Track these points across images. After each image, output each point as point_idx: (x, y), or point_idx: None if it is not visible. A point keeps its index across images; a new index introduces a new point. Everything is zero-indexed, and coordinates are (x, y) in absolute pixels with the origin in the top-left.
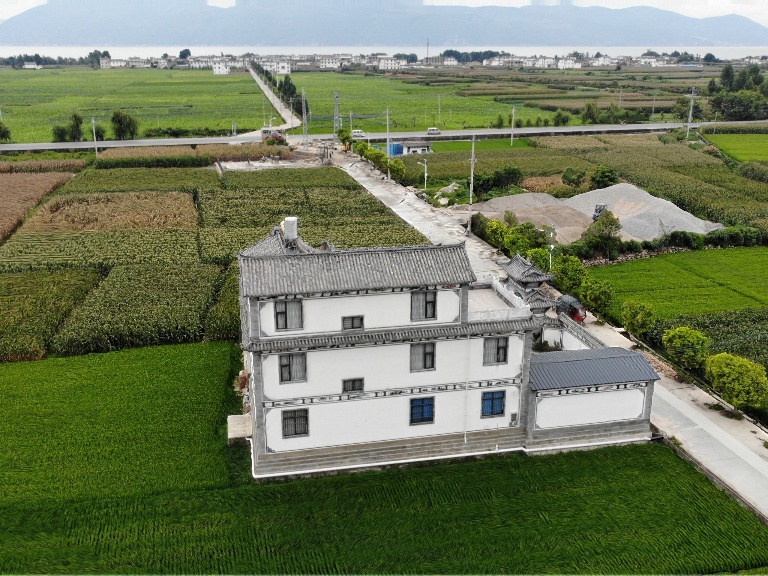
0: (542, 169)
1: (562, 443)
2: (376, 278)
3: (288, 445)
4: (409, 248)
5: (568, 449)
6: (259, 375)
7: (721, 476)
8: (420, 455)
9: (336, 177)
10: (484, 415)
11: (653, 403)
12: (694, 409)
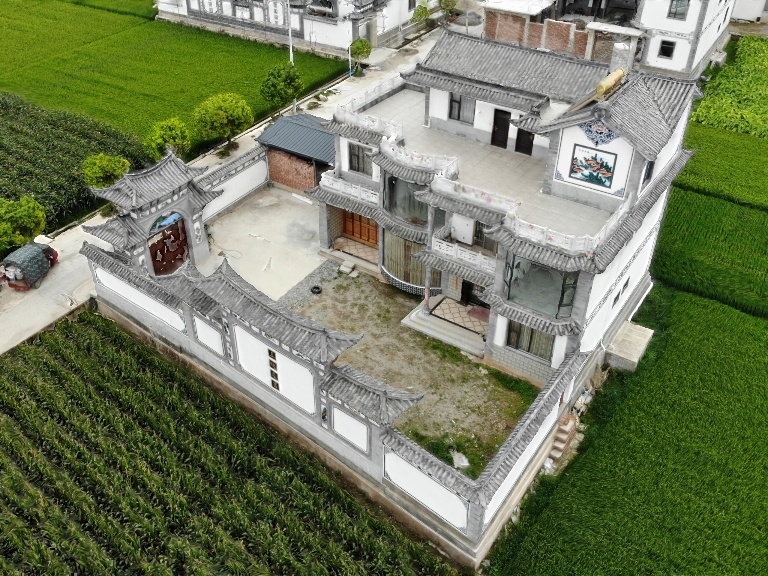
0: None
1: None
2: None
3: None
4: None
5: None
6: None
7: None
8: None
9: None
10: None
11: None
12: None
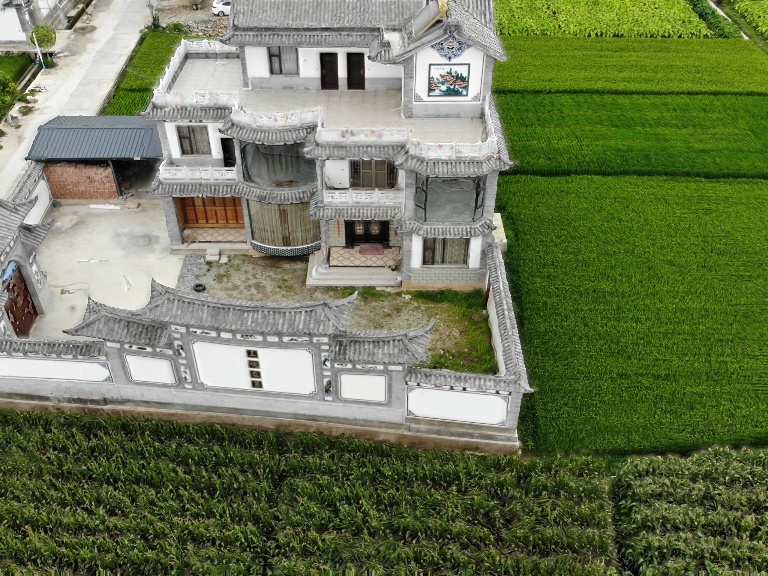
0: None
1: None
2: None
3: None
4: None
5: None
6: None
7: None
8: None
9: None
10: None
11: None
12: None
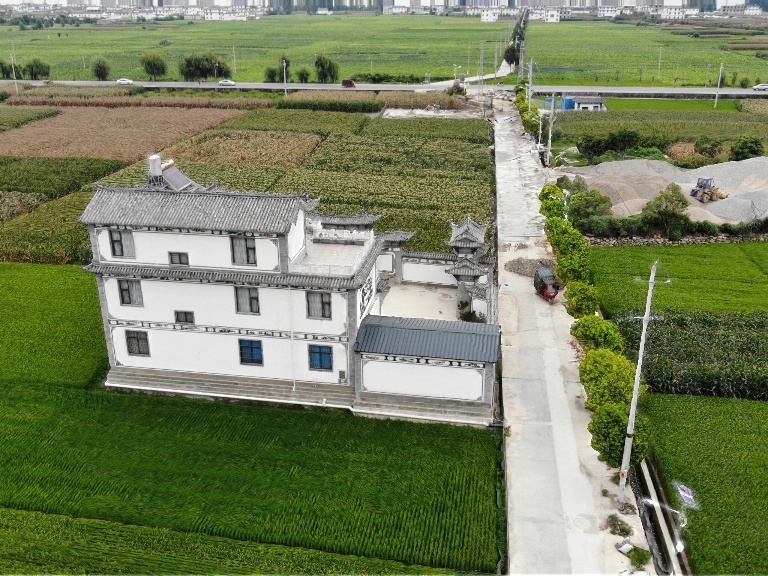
0: (707, 135)
1: (391, 410)
2: (197, 219)
3: (134, 362)
4: (246, 194)
5: (397, 417)
6: (103, 295)
7: (511, 475)
8: (251, 394)
9: (471, 129)
10: (313, 367)
11: (530, 391)
12: (567, 405)
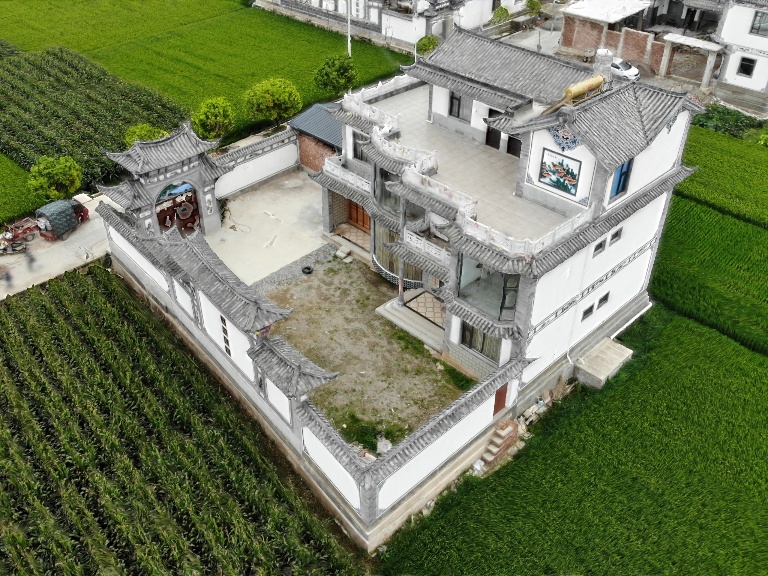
0: None
1: None
2: None
3: None
4: None
5: None
6: None
7: None
8: None
9: None
10: None
11: None
12: None
